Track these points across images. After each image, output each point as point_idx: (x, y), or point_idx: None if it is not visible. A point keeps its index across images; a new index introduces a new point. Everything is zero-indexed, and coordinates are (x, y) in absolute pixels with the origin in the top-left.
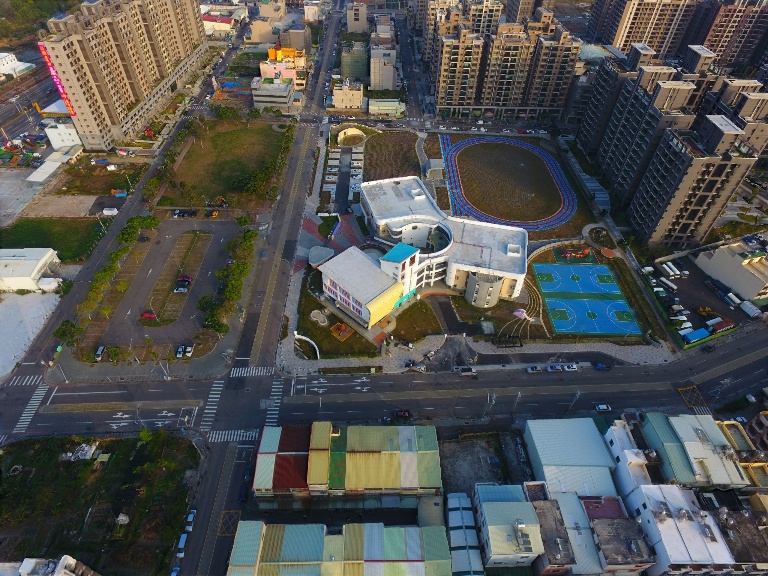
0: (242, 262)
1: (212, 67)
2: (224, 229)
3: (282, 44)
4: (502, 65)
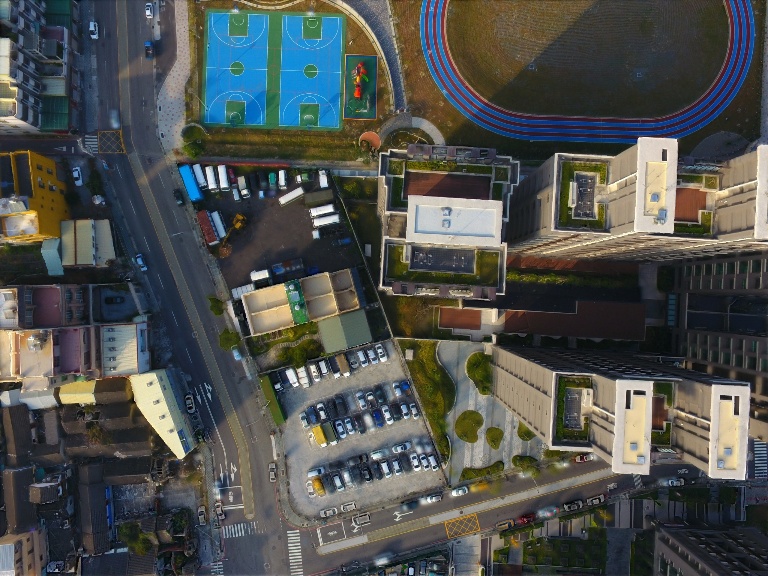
0: None
1: None
2: None
3: None
4: None
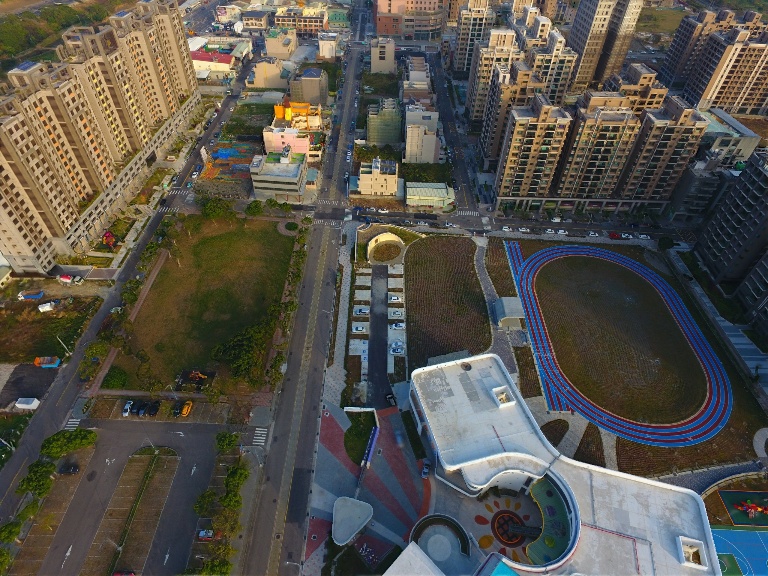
0: (220, 554)
1: (204, 126)
2: (198, 443)
3: (292, 94)
4: (593, 149)
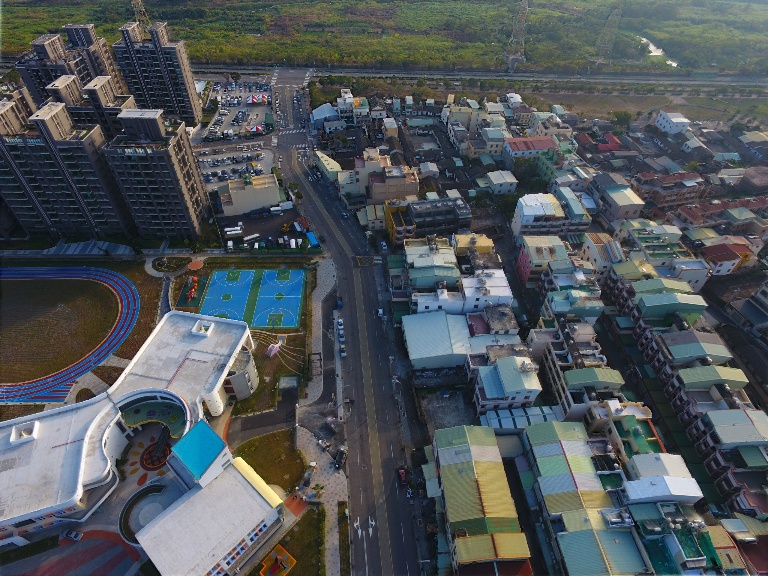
0: None
1: None
2: None
3: None
4: None
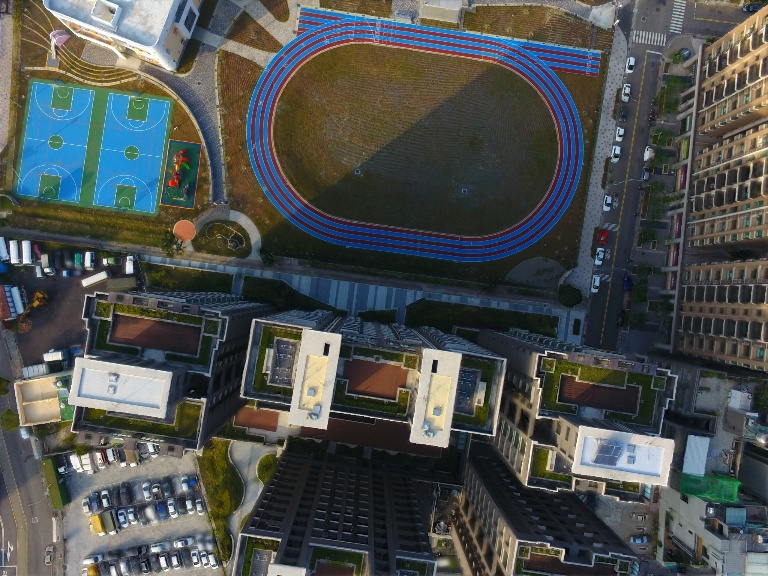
0: None
1: None
2: None
3: None
4: None
